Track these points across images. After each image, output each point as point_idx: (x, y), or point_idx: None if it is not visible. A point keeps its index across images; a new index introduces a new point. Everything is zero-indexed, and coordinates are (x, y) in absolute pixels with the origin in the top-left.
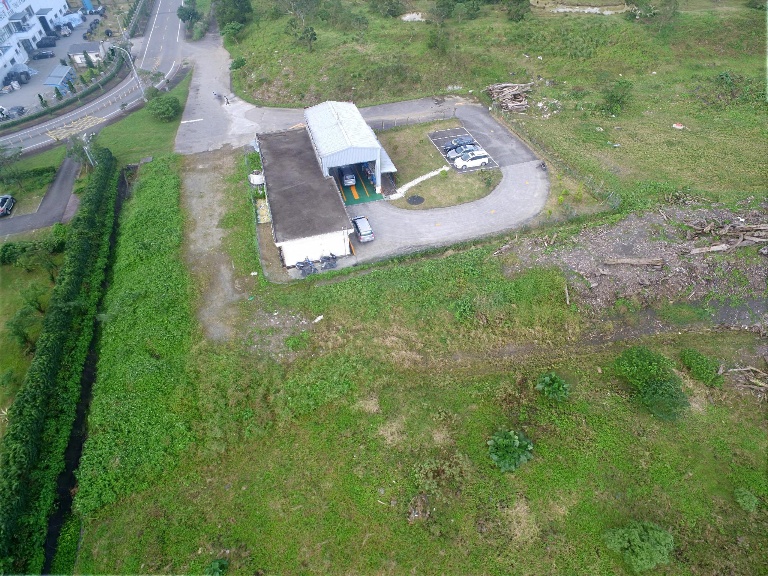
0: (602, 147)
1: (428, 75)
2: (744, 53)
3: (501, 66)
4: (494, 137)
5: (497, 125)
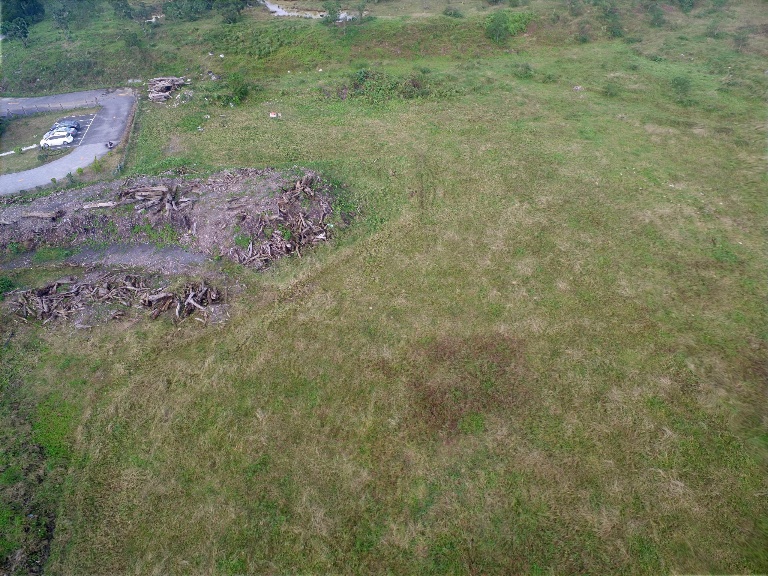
0: (185, 131)
1: (112, 69)
2: (418, 54)
3: (182, 62)
4: (109, 122)
5: (126, 112)
